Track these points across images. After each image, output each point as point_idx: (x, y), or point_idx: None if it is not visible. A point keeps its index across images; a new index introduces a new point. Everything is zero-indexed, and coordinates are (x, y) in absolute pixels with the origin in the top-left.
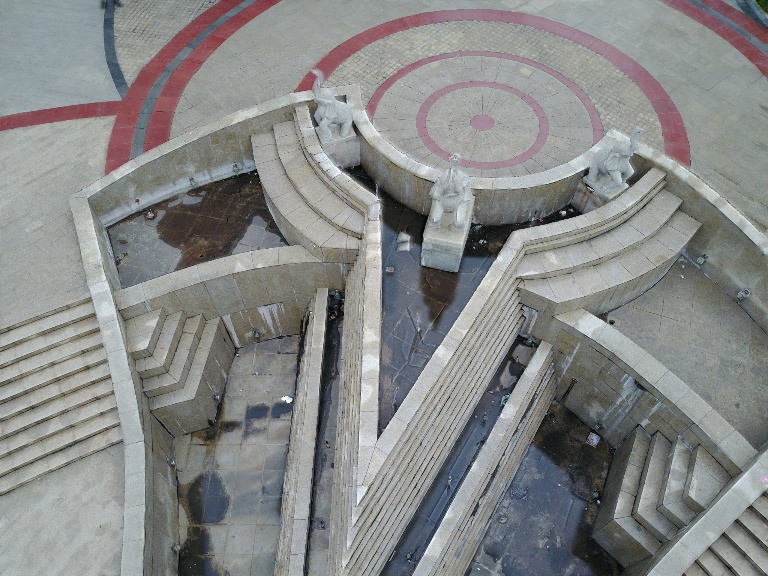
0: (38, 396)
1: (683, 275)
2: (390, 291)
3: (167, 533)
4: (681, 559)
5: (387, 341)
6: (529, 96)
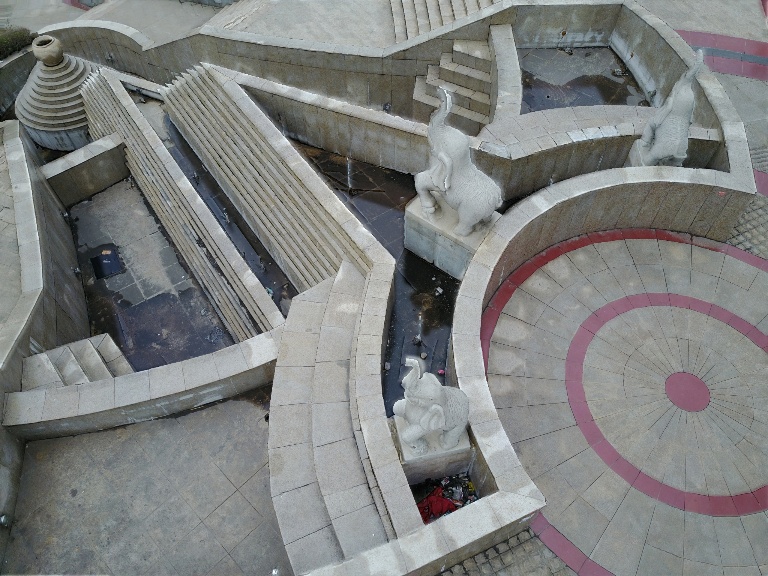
0: (445, 8)
1: (276, 574)
2: (413, 185)
3: (329, 95)
4: (17, 318)
5: (355, 165)
6: (759, 511)
